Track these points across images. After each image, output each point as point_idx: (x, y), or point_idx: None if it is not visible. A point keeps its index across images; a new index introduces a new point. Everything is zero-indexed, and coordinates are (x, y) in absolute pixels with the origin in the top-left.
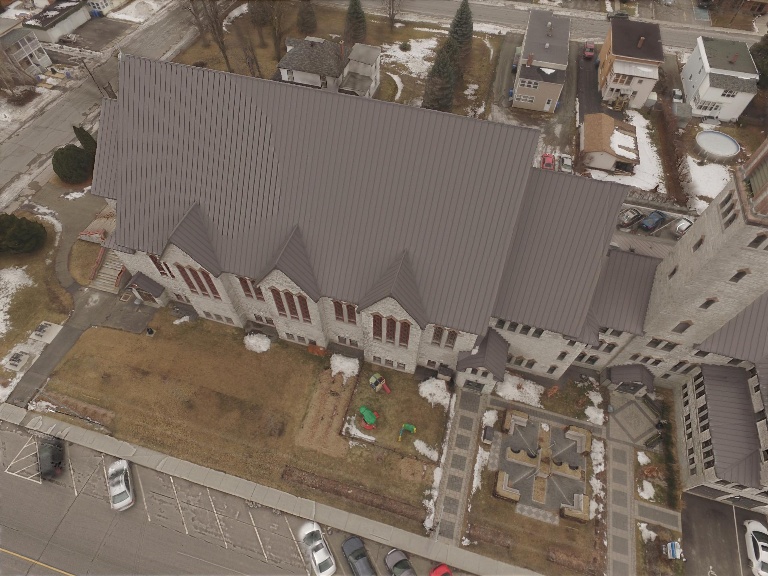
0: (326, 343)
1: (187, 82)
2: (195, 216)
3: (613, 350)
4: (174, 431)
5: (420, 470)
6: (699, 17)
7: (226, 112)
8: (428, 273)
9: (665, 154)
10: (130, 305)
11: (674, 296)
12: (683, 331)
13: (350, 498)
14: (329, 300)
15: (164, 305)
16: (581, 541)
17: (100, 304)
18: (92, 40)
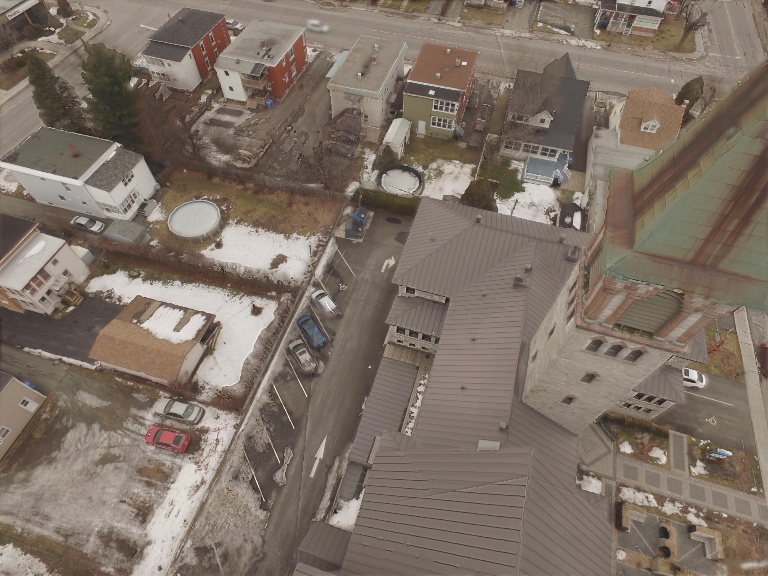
0: None
1: None
2: None
3: None
4: None
5: None
6: None
7: None
8: None
9: (192, 275)
10: None
11: None
12: None
13: None
14: None
15: None
16: (732, 542)
17: None
18: None
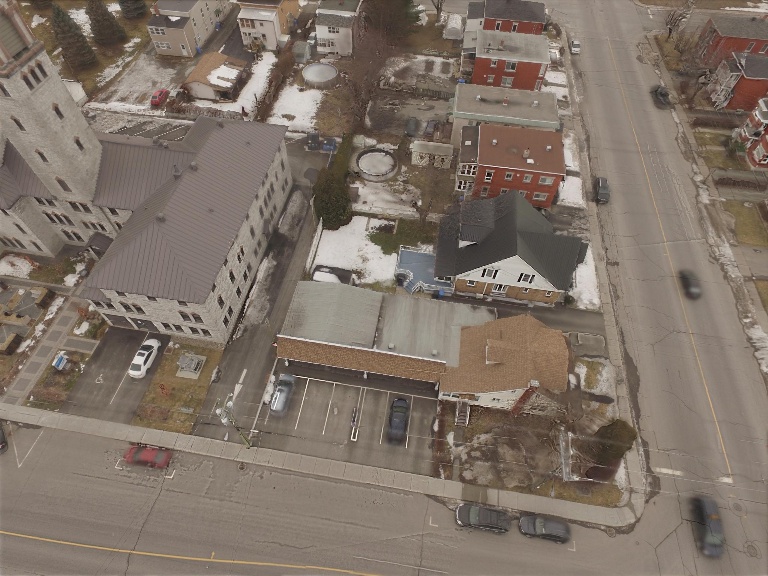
0: None
1: None
2: None
3: (73, 222)
4: None
5: None
6: None
7: None
8: None
9: None
10: None
11: None
12: (70, 189)
13: None
14: None
15: None
16: (0, 368)
17: None
18: None
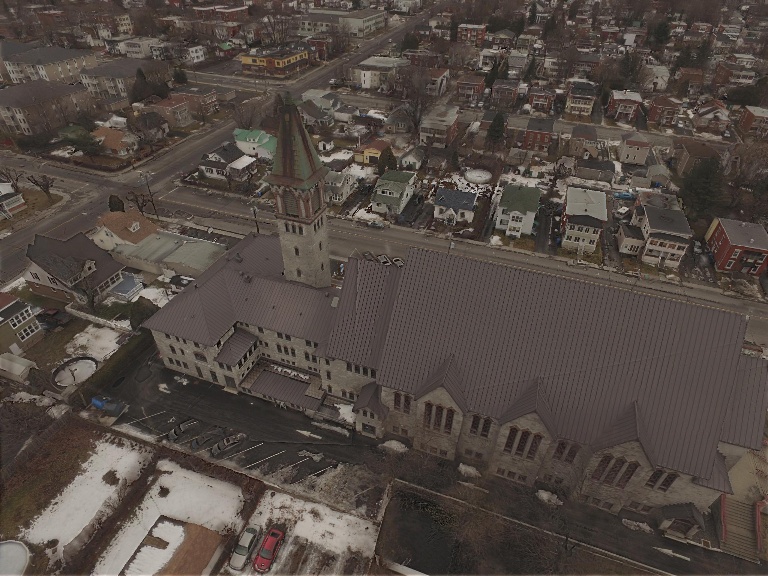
0: None
1: None
2: None
3: None
4: None
5: None
6: None
7: None
8: None
9: (84, 567)
10: None
11: None
12: None
13: None
14: None
15: None
16: None
17: None
18: None
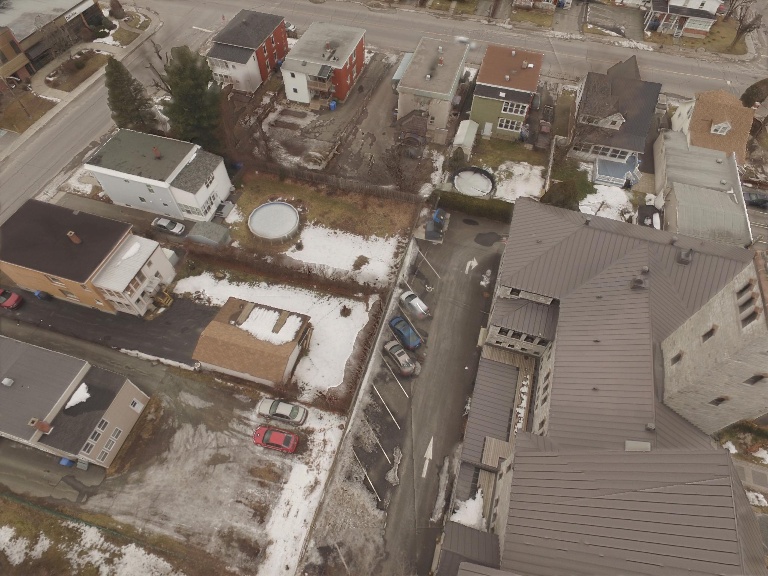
0: None
1: None
2: None
3: None
4: None
5: None
6: None
7: None
8: None
9: (277, 277)
10: None
11: None
12: None
13: None
14: None
15: None
16: None
17: None
18: None
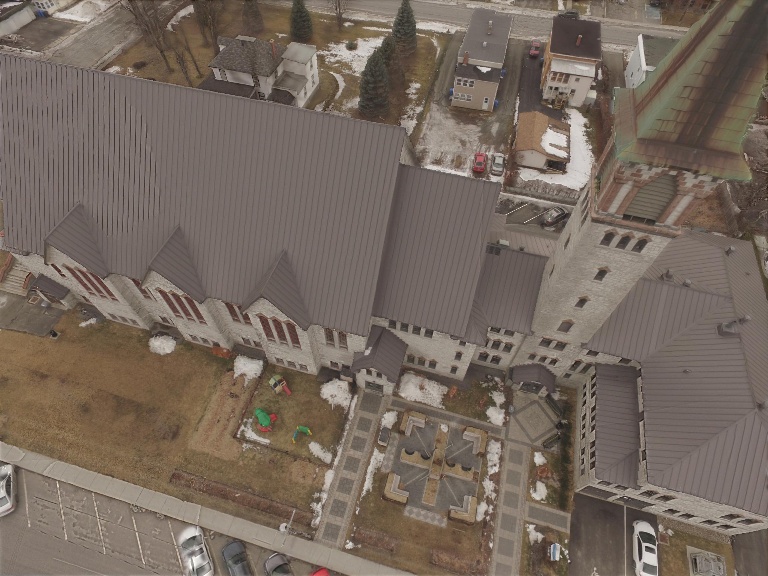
0: (230, 345)
1: (62, 81)
2: (78, 217)
3: (512, 350)
4: (66, 435)
5: (311, 473)
6: (650, 15)
7: (102, 111)
8: (307, 273)
9: (600, 152)
10: (37, 307)
11: (549, 295)
12: (568, 330)
13: (237, 502)
14: (220, 301)
15: (71, 307)
16: (467, 543)
17: (7, 307)
18: (34, 40)
